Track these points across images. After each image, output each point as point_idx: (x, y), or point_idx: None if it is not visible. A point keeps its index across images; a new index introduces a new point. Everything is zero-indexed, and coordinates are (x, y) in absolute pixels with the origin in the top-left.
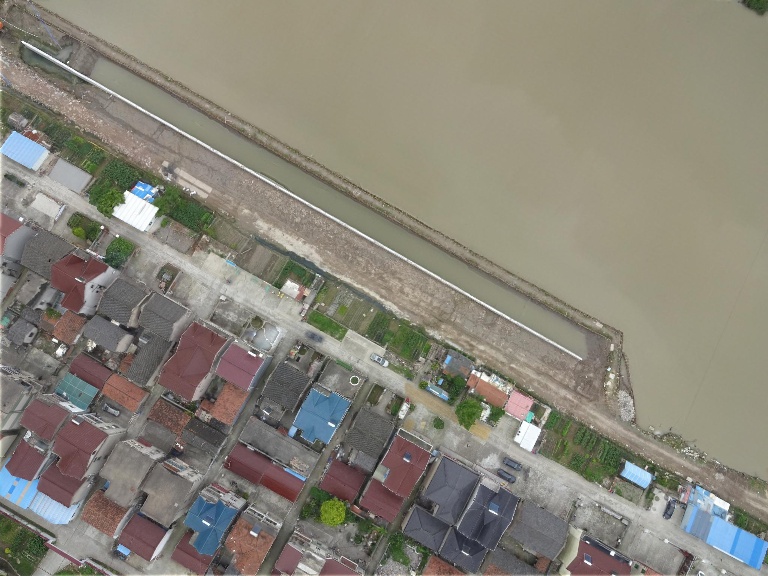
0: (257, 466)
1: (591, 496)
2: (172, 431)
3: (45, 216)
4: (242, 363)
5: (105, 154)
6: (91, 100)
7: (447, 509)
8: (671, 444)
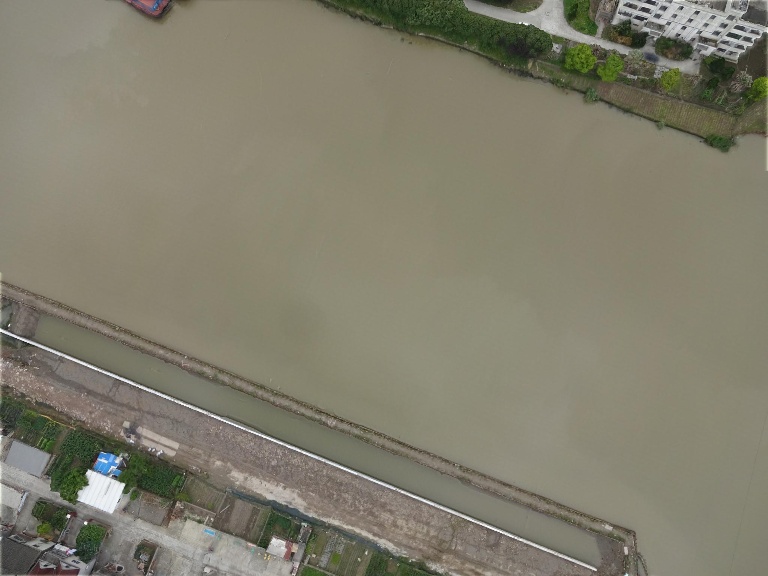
0: None
1: None
2: None
3: (7, 508)
4: None
5: (61, 428)
6: (39, 365)
7: None
8: None
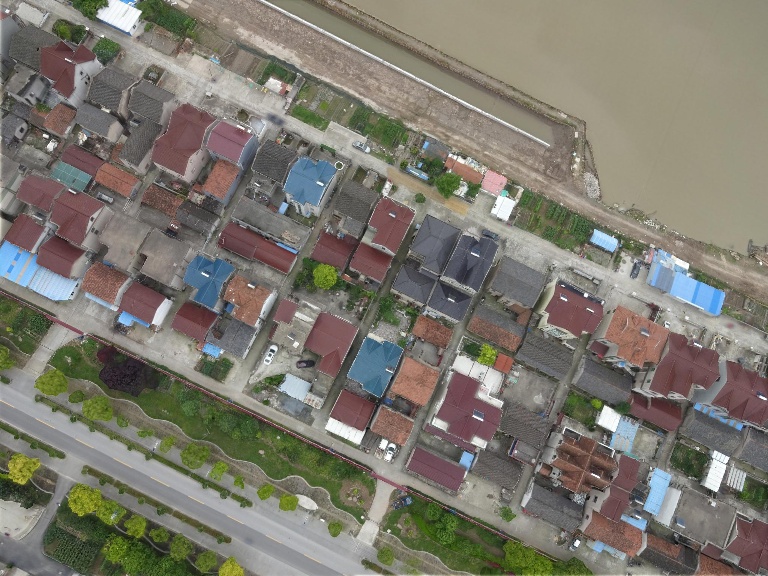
0: (250, 240)
1: (564, 261)
2: (166, 213)
3: (29, 23)
4: (232, 136)
5: None
6: None
7: (432, 258)
8: (634, 217)
